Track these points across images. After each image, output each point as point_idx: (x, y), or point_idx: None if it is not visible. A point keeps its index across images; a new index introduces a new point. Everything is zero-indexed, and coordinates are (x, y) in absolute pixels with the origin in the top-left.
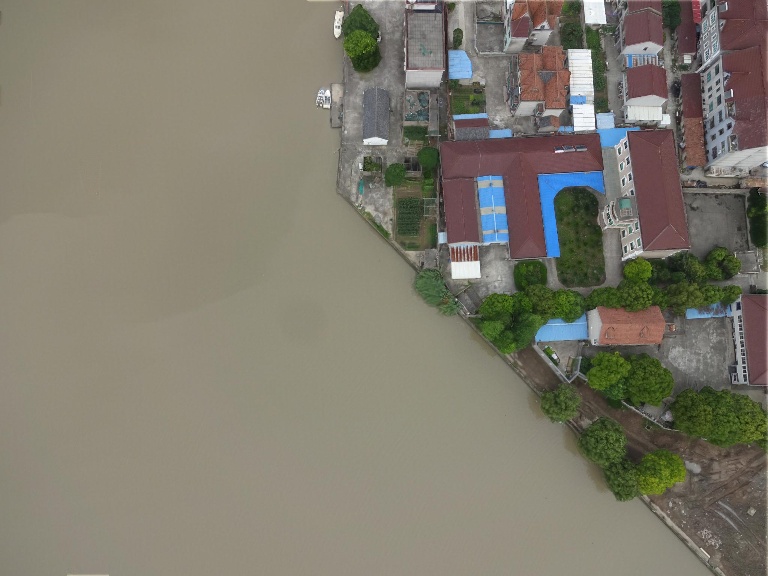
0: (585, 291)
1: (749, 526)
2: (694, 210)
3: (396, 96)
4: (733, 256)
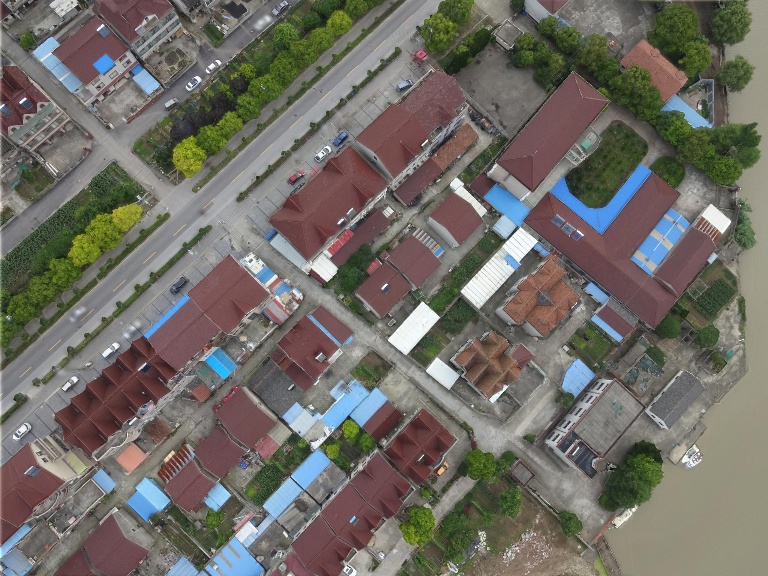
0: (636, 127)
1: None
2: (497, 105)
3: None
4: (522, 45)
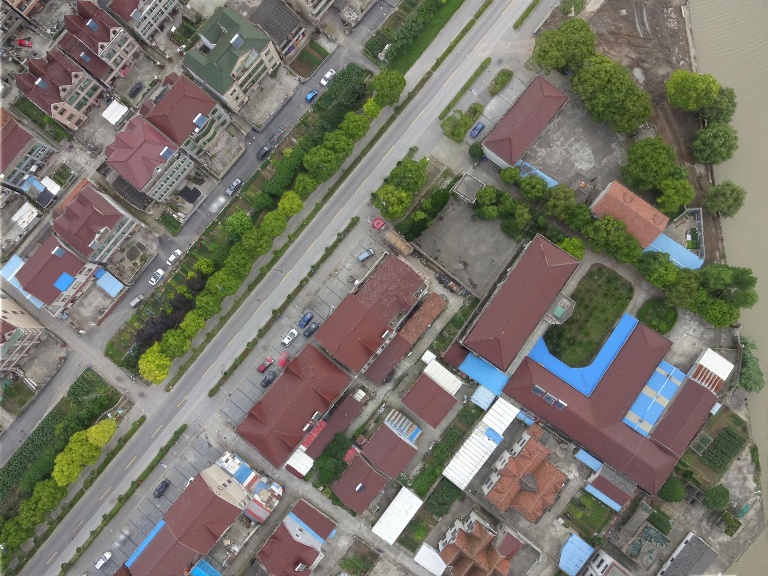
0: (619, 269)
1: (634, 4)
2: (465, 263)
3: (645, 572)
4: (484, 201)
